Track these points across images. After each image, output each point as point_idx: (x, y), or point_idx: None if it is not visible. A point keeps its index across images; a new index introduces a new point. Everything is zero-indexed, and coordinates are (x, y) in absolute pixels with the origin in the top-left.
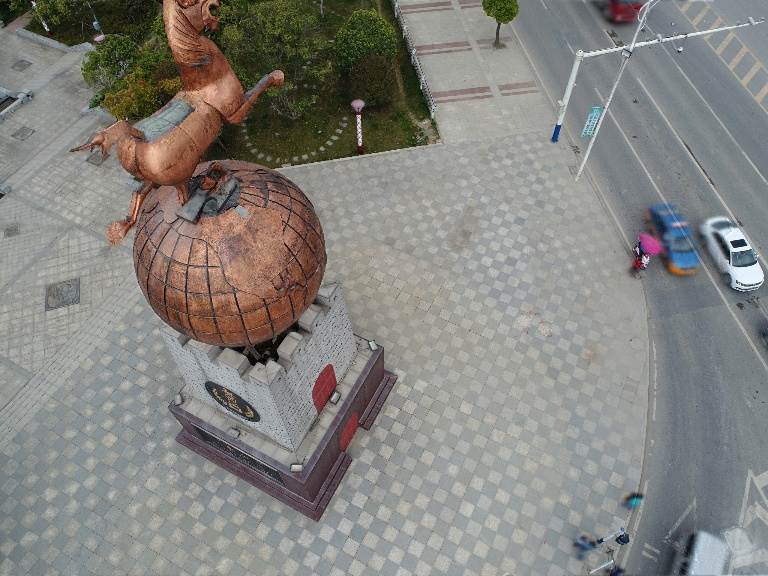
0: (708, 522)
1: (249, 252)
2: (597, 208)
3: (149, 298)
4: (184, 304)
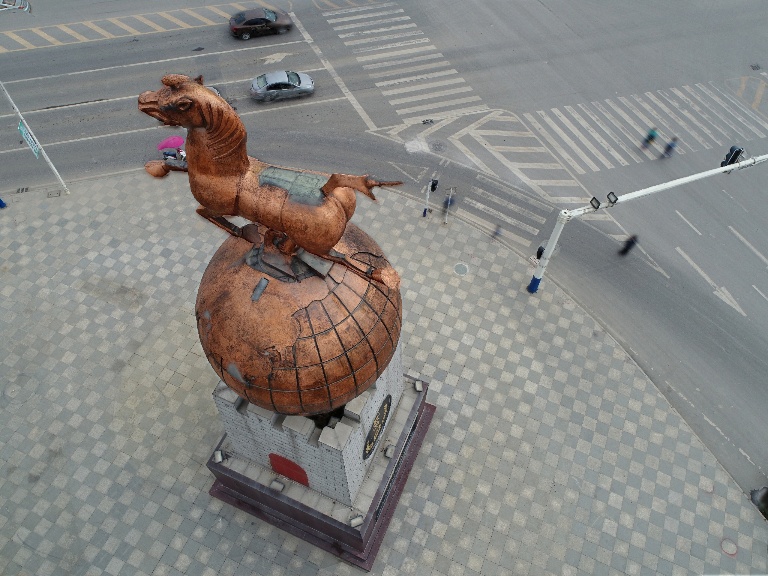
0: (403, 158)
1: (353, 232)
2: (111, 182)
3: (376, 362)
4: (394, 309)
